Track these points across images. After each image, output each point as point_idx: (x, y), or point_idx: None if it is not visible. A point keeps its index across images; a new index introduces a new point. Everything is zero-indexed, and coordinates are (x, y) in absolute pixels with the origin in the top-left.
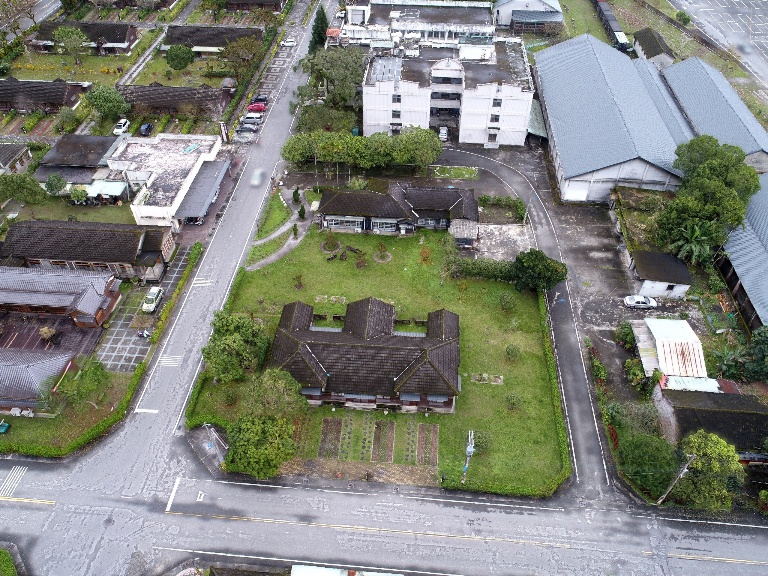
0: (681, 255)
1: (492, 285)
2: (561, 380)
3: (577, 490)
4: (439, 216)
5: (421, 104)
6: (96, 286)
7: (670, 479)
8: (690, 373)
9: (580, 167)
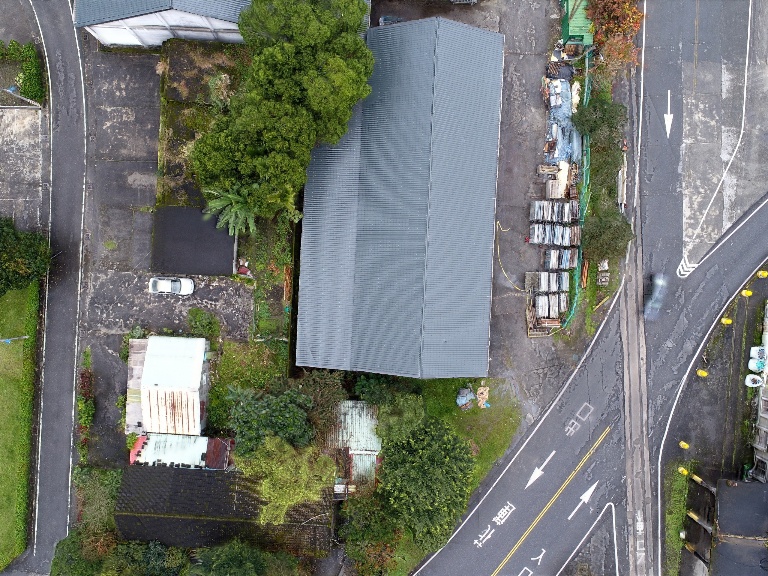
0: (220, 225)
1: None
2: (41, 419)
3: (31, 564)
4: None
5: None
6: None
7: None
8: (179, 430)
9: (96, 2)
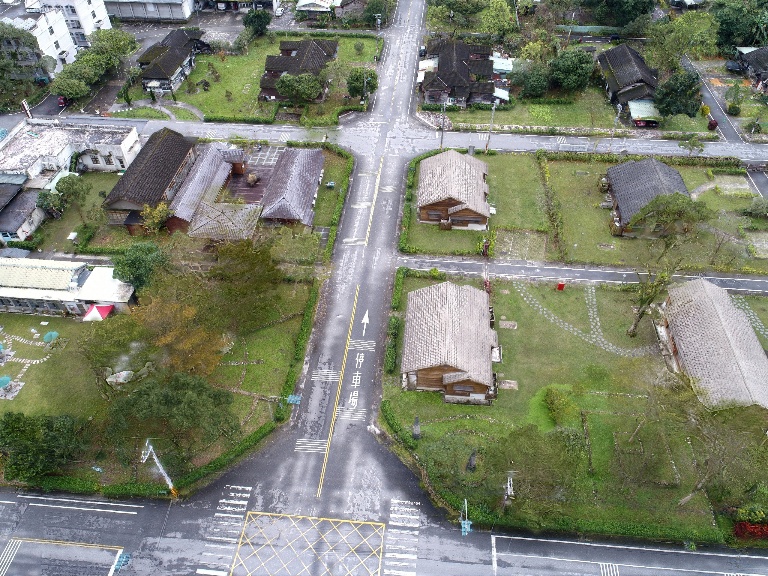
0: None
1: (252, 45)
2: None
3: (380, 36)
4: (191, 45)
5: (62, 27)
6: (220, 148)
7: (384, 7)
8: (331, 3)
9: None
